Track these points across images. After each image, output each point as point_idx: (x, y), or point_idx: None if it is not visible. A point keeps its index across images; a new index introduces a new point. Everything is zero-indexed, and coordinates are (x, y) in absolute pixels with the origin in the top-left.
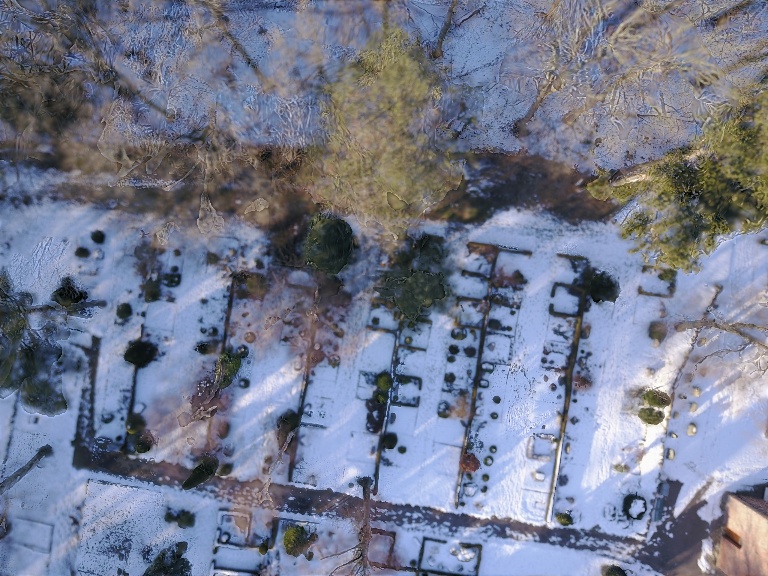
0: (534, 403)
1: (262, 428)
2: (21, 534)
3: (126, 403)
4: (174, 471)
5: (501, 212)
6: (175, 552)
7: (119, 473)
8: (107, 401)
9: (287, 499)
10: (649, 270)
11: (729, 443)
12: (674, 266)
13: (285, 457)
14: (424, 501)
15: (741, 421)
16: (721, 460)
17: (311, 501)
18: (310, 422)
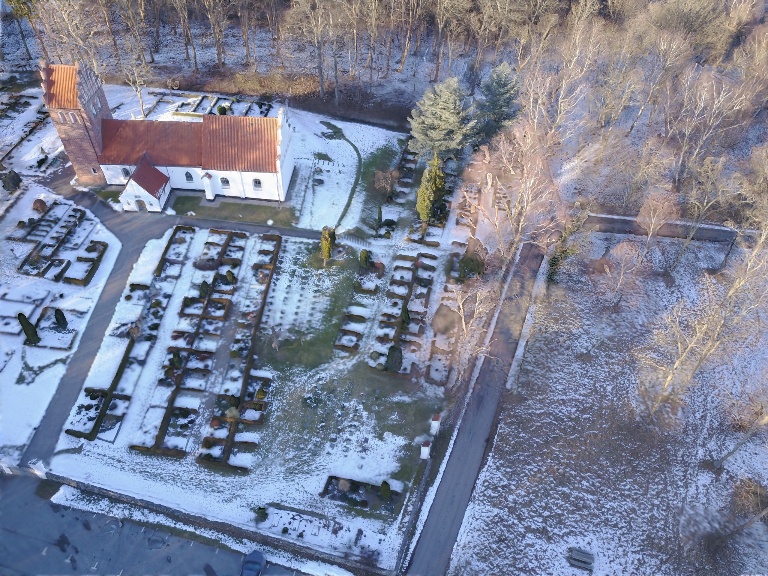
0: None
1: None
2: None
3: None
4: None
5: None
6: None
7: None
8: None
9: None
10: None
11: None
12: (17, 2)
13: None
14: None
15: None
16: None
17: None
18: None
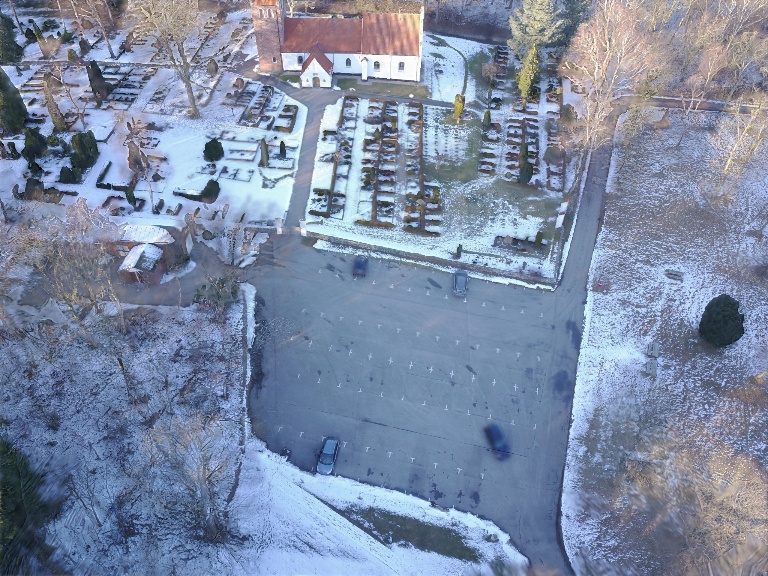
0: None
1: None
2: None
3: None
4: None
5: None
6: None
7: (3, 65)
8: None
9: None
10: None
11: None
12: None
13: None
14: (137, 62)
15: None
16: None
17: None
18: None
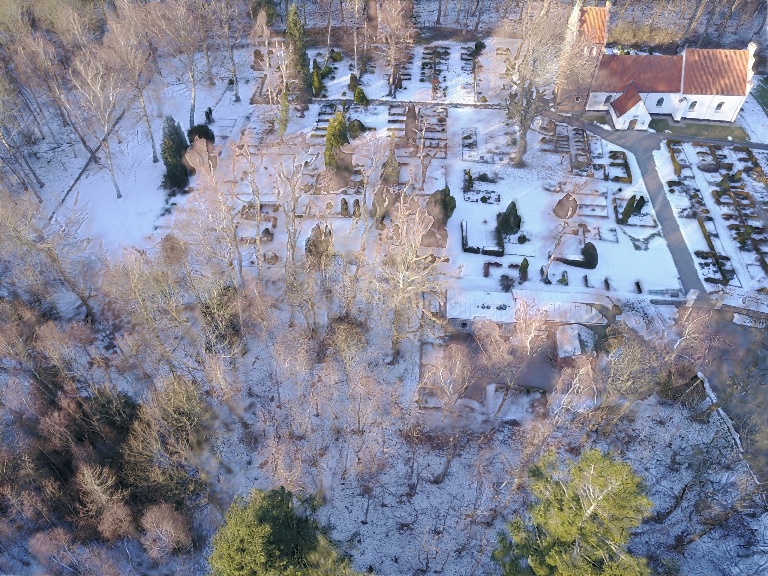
0: None
1: (341, 88)
2: (219, 123)
3: None
4: None
5: (436, 41)
6: (300, 111)
7: None
8: None
9: None
10: (499, 51)
11: None
12: None
13: None
14: None
15: None
16: None
17: None
18: None
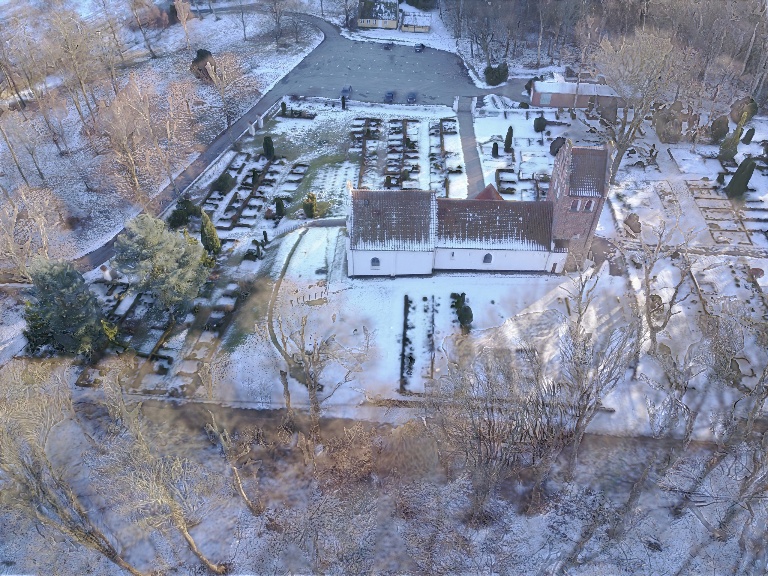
0: None
1: None
2: None
3: None
4: None
5: None
6: None
7: None
8: None
9: None
10: None
11: None
12: None
13: None
14: (764, 261)
15: None
16: None
17: None
18: None
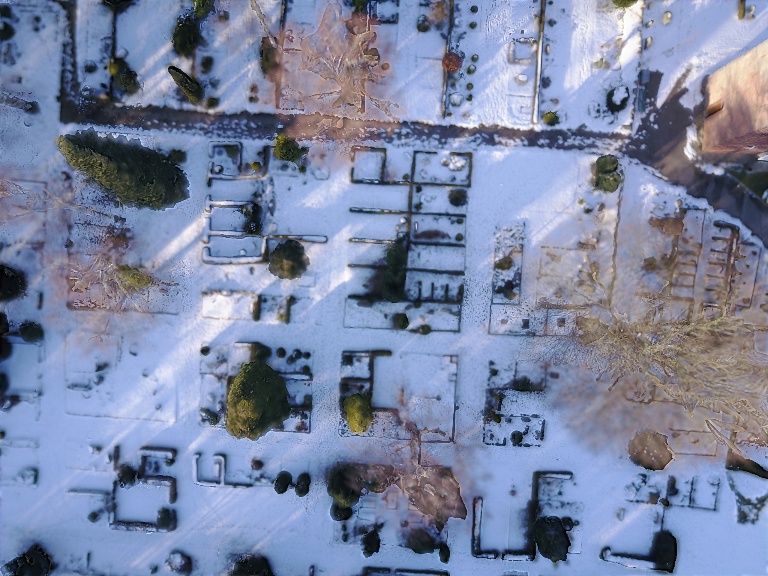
0: (511, 9)
1: (245, 60)
2: None
3: (108, 52)
4: (162, 114)
5: None
6: None
7: (107, 123)
8: (89, 53)
9: (276, 127)
10: None
11: (704, 29)
12: None
13: (271, 85)
14: (411, 116)
15: (714, 6)
16: (698, 45)
17: (300, 127)
18: (292, 47)
